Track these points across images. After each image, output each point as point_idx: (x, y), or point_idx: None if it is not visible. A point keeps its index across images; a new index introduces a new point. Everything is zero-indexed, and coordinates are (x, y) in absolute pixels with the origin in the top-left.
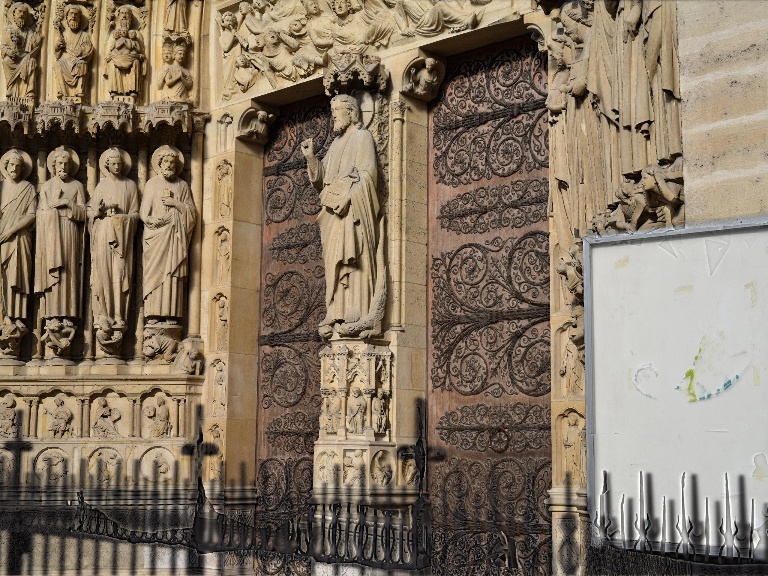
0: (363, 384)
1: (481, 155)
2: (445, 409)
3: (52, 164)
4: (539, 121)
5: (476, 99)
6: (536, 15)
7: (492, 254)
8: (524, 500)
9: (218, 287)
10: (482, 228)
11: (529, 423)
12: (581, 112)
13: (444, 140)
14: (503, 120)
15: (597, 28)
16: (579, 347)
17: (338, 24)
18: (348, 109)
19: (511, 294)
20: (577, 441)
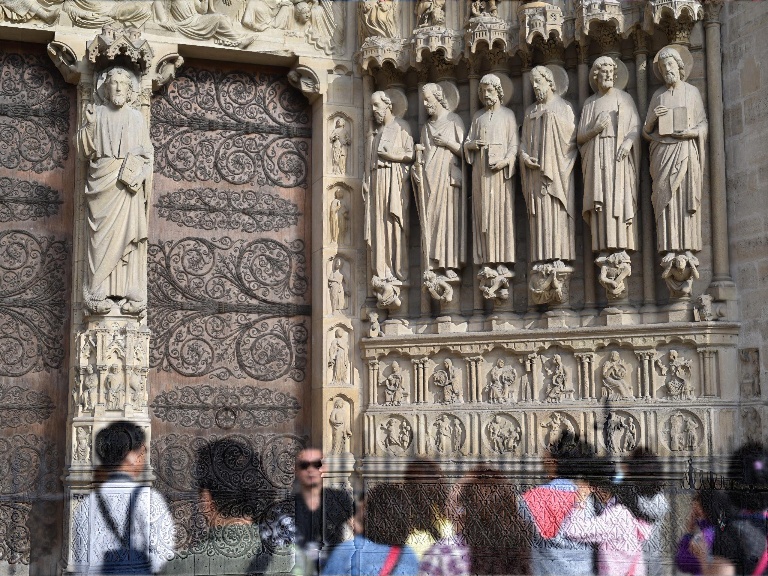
0: (138, 362)
1: (209, 158)
2: (162, 388)
3: None
4: (273, 144)
5: (204, 105)
6: (312, 61)
7: (220, 251)
8: (252, 470)
9: None
10: (209, 225)
11: (259, 404)
12: (492, 181)
13: (164, 133)
14: (236, 133)
15: (552, 134)
16: (375, 346)
17: None
18: (129, 86)
19: (241, 290)
20: (345, 420)
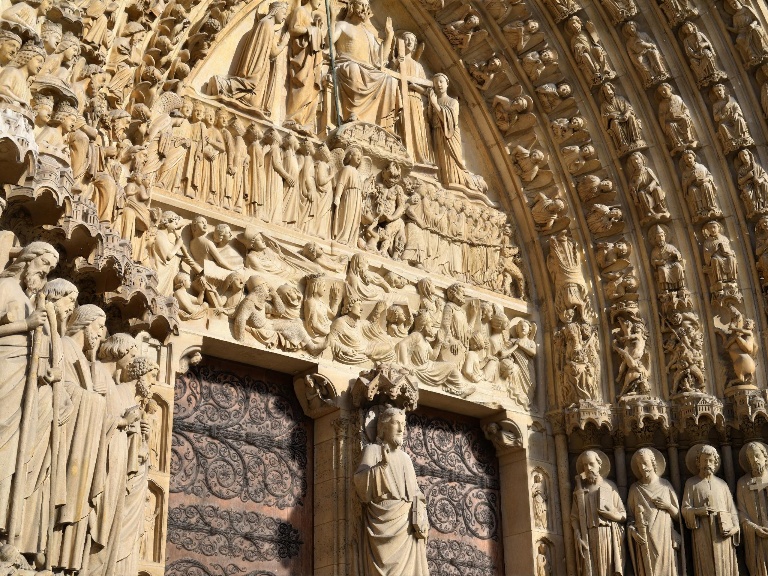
0: None
1: None
2: None
3: (88, 321)
4: (470, 494)
5: (415, 450)
6: (516, 415)
7: None
8: None
9: (142, 563)
10: None
11: None
12: None
13: None
14: (442, 480)
15: None
16: None
17: (347, 322)
18: None
19: None
20: None
